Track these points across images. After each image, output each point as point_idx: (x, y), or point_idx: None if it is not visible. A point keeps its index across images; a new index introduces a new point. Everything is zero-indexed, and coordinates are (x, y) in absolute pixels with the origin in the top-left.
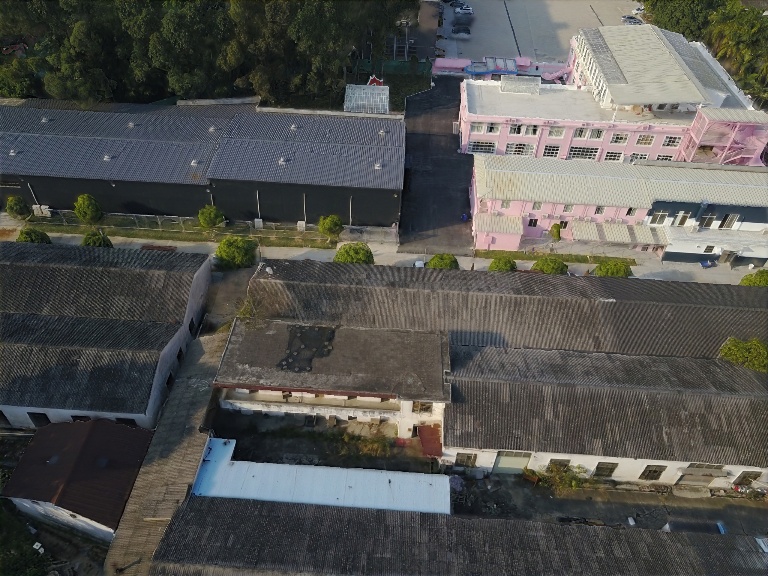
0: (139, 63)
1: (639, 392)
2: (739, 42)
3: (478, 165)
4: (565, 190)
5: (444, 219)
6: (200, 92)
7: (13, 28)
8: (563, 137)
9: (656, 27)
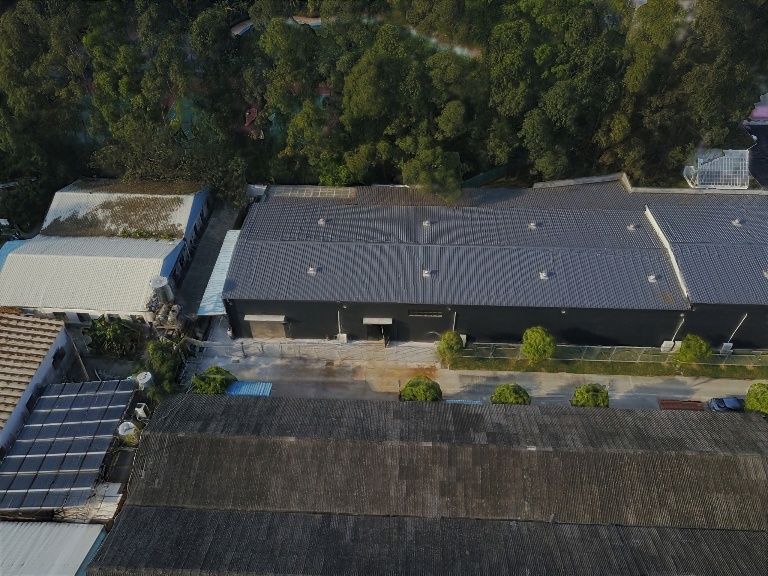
0: (497, 142)
1: None
2: None
3: None
4: None
5: None
6: (563, 172)
7: (370, 112)
8: None
9: None
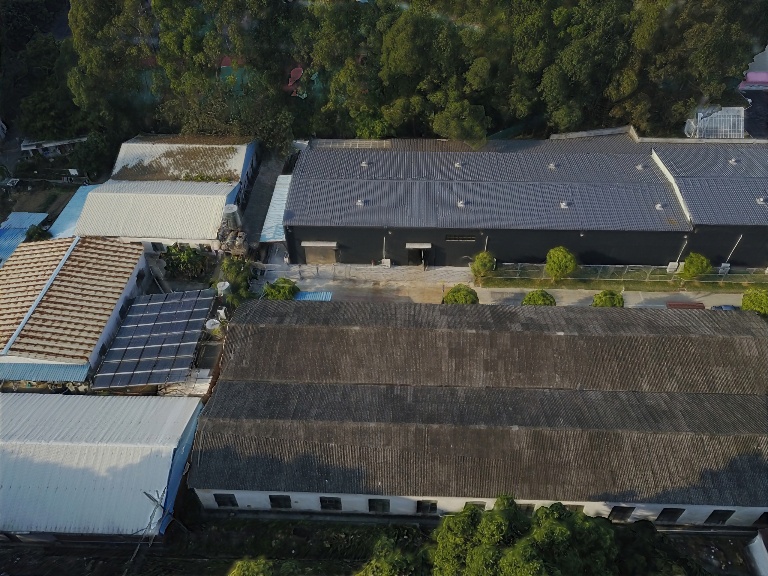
0: (517, 97)
1: None
2: None
3: None
4: None
5: None
6: None
7: (406, 68)
8: None
9: None
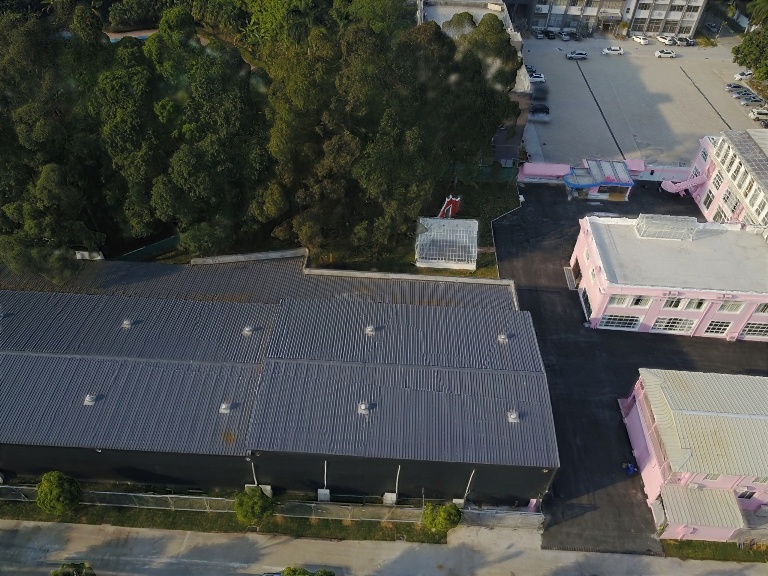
0: (137, 210)
1: None
2: None
3: (653, 395)
4: None
5: (598, 470)
6: (224, 248)
7: None
8: (739, 312)
9: None
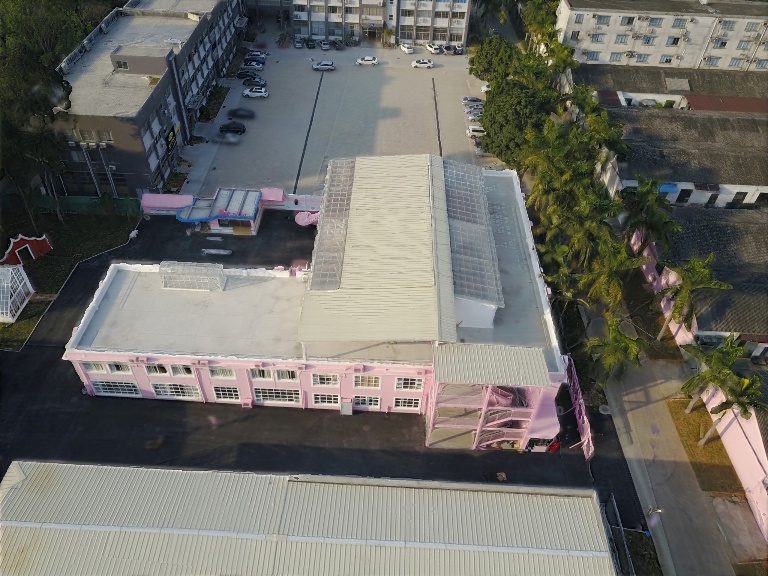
0: None
1: None
2: (549, 190)
3: None
4: (115, 575)
5: None
6: None
7: None
8: (235, 378)
9: (438, 159)
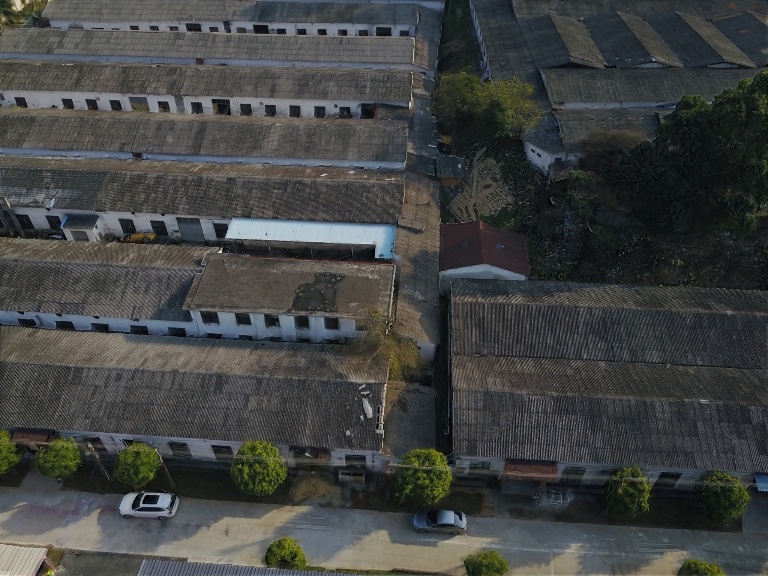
0: None
1: (49, 260)
2: None
3: None
4: None
5: None
6: None
7: None
8: None
9: None
